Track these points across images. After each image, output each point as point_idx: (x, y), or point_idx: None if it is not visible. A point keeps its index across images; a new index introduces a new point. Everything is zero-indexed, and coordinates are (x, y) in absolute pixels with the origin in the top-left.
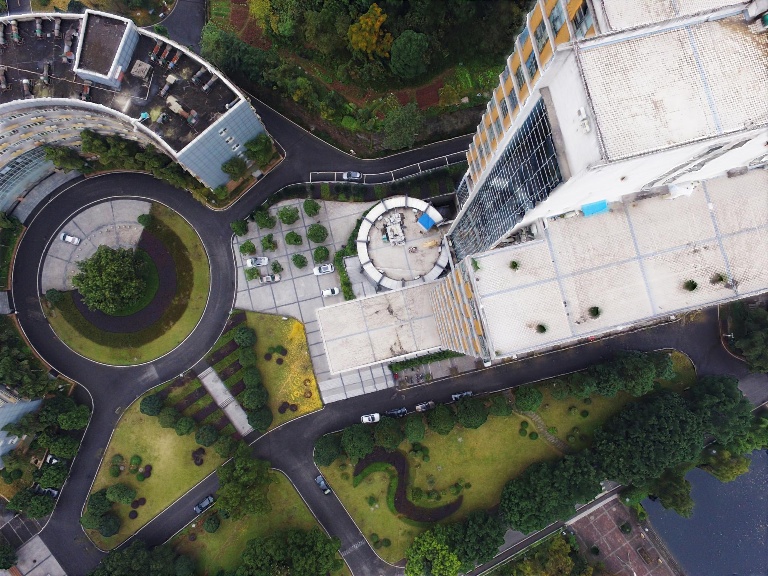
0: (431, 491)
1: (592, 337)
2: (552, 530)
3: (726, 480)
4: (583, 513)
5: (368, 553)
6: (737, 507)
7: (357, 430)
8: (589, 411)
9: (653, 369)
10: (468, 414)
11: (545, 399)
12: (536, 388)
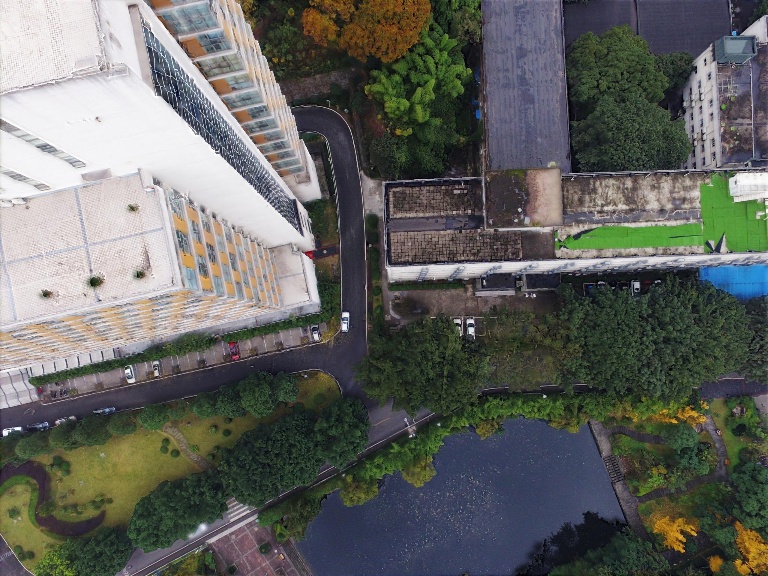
0: (68, 506)
1: (236, 356)
2: (193, 548)
3: None
4: (224, 532)
5: (15, 564)
6: (384, 530)
7: None
8: (232, 430)
9: (256, 392)
10: (75, 432)
11: (188, 417)
12: (163, 407)
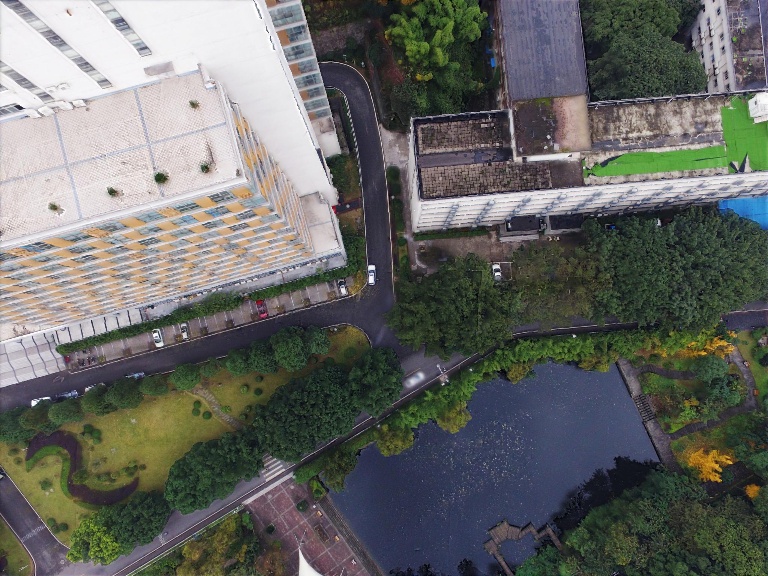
0: (101, 474)
1: (264, 314)
2: (229, 510)
3: (385, 454)
4: (260, 492)
5: (48, 538)
6: (420, 482)
7: (5, 413)
8: (264, 389)
9: (289, 343)
10: (108, 393)
11: (218, 378)
12: None
